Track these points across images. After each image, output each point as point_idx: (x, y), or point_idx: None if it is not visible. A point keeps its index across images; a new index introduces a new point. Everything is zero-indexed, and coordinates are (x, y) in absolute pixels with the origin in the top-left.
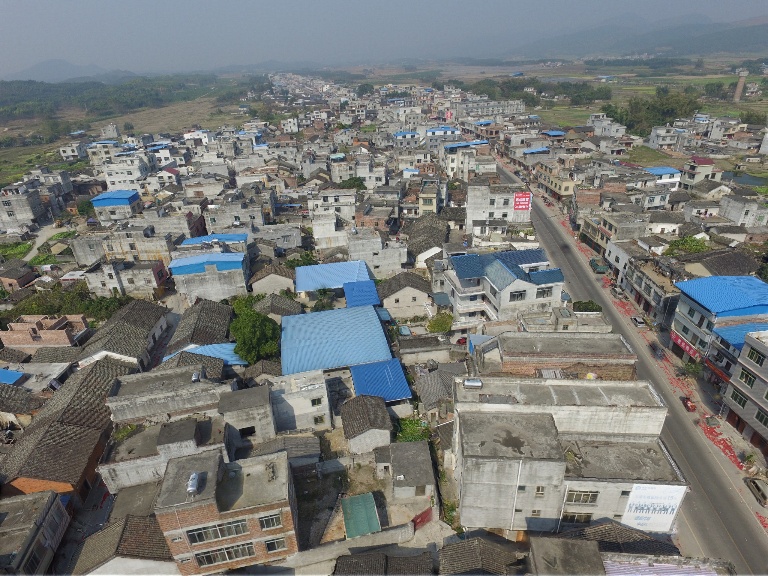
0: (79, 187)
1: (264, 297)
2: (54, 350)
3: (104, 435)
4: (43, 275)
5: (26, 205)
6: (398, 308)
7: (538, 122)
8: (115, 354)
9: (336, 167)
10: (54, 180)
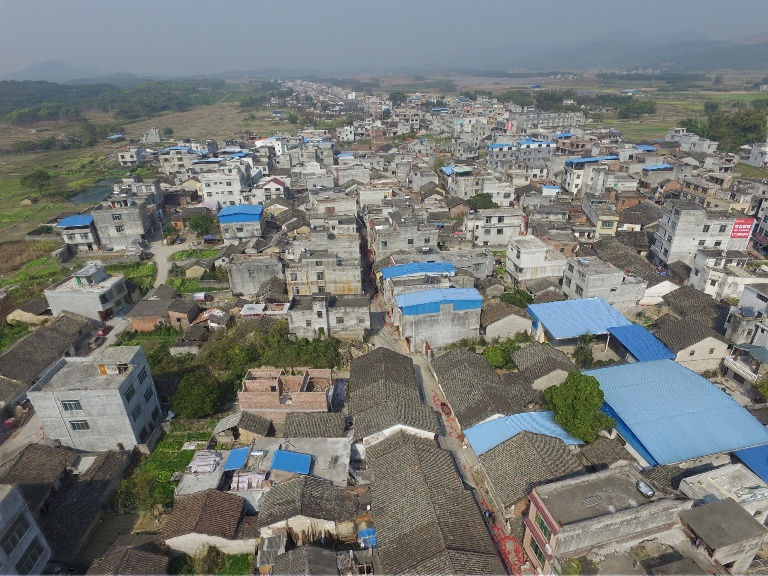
0: (166, 197)
1: (497, 341)
2: (309, 417)
3: (503, 564)
4: (212, 308)
5: (137, 219)
6: (690, 361)
7: (621, 136)
8: (412, 428)
9: (462, 182)
10: (147, 190)
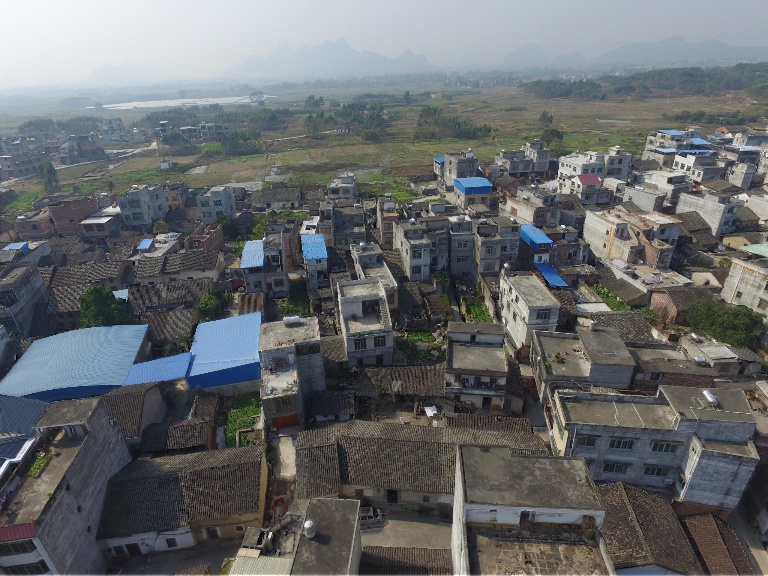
0: None
1: None
2: None
3: None
4: None
5: (456, 168)
6: None
7: None
8: None
9: (740, 269)
10: (533, 156)
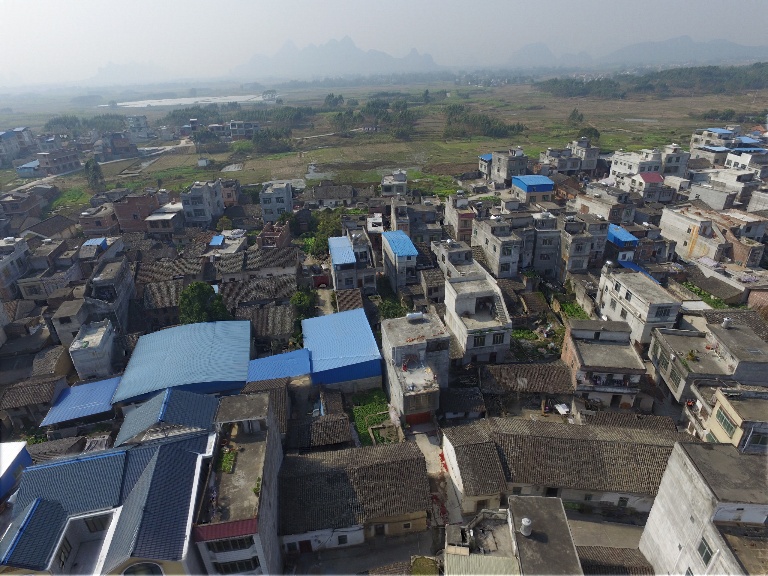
0: None
1: None
2: None
3: None
4: None
5: (506, 166)
6: None
7: None
8: None
9: None
10: (581, 154)
